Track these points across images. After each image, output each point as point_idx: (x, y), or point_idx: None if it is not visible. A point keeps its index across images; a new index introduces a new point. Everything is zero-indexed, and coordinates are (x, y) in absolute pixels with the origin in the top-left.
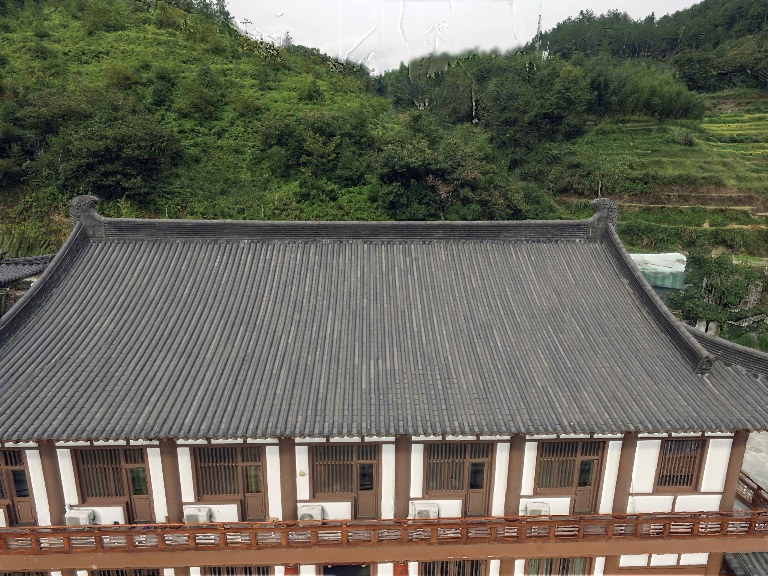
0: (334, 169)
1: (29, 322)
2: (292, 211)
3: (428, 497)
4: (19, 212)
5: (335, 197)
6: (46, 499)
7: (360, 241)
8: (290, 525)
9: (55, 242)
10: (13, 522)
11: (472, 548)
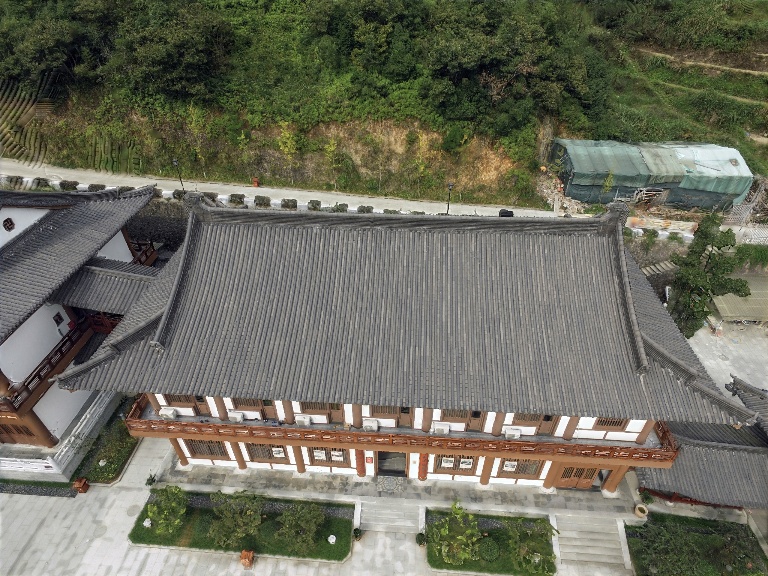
0: (385, 62)
1: (181, 300)
2: (344, 108)
3: (444, 420)
4: (102, 113)
5: (386, 93)
6: (215, 406)
7: (407, 230)
8: (358, 428)
9: (139, 142)
10: (198, 413)
11: (468, 452)
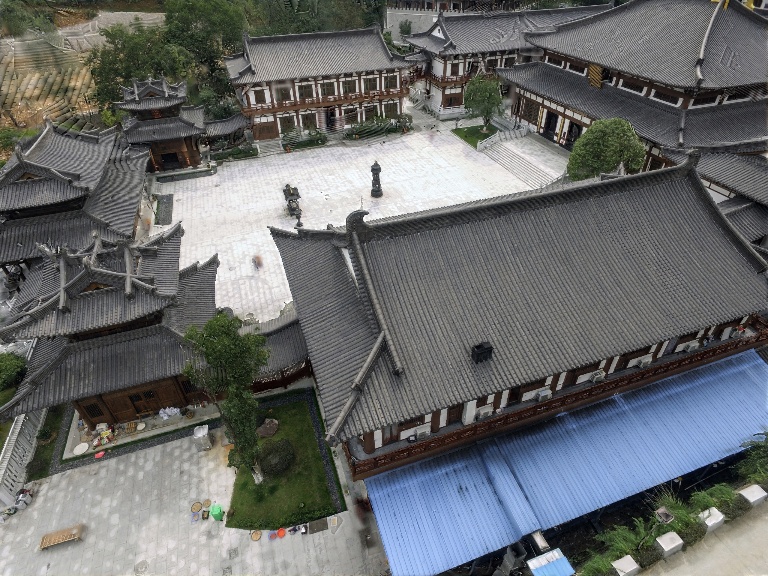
0: None
1: None
2: None
3: None
4: None
5: None
6: None
7: None
8: None
9: None
10: None
11: None
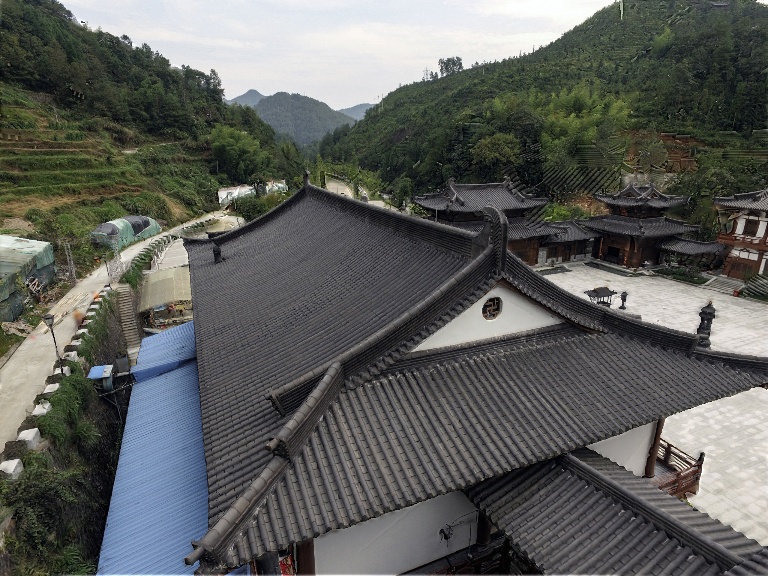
0: None
1: None
2: None
3: None
4: None
5: None
6: None
7: None
8: None
9: None
10: None
11: None
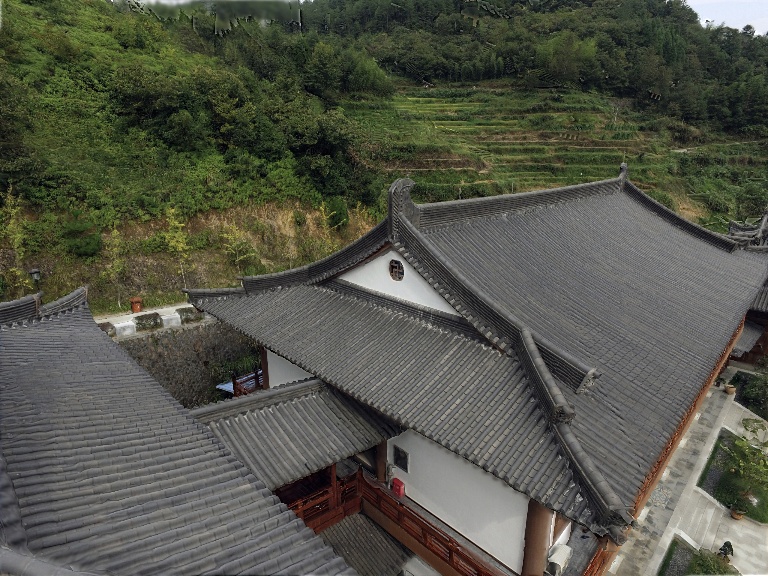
0: (255, 140)
1: None
2: (224, 192)
3: None
4: None
5: (265, 173)
6: None
7: (554, 205)
8: None
9: None
10: None
11: None
